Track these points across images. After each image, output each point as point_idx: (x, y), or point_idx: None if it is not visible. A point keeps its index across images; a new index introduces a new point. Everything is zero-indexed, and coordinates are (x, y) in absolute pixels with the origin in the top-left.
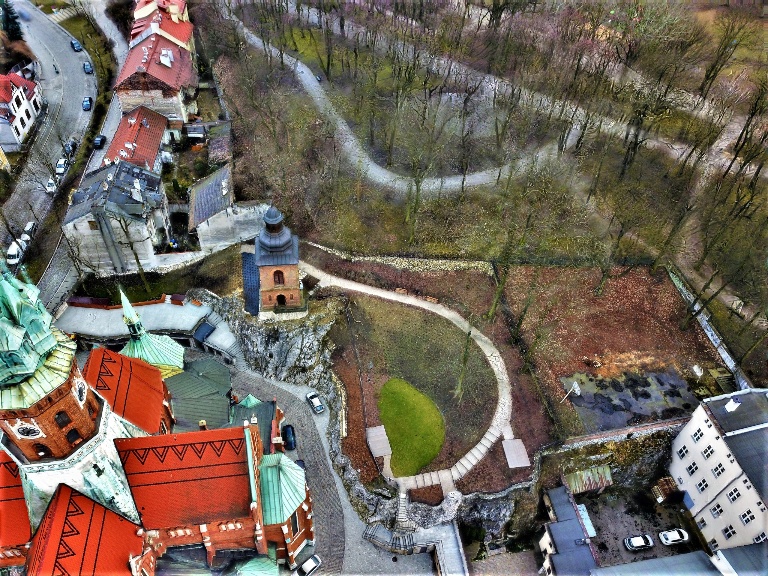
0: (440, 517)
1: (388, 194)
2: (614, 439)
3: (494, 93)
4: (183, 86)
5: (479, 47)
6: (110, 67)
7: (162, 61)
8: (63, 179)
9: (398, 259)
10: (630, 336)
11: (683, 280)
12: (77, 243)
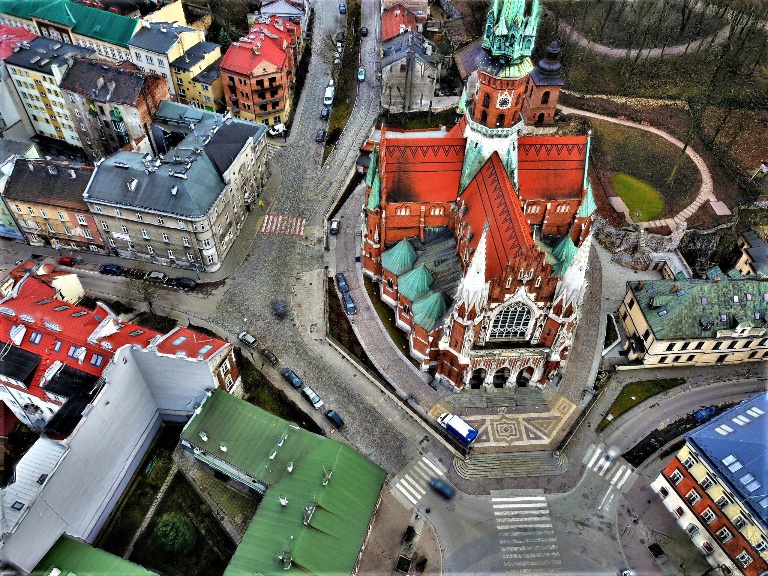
0: (669, 245)
1: (605, 57)
2: None
3: None
4: None
5: None
6: None
7: None
8: (342, 56)
9: (619, 97)
10: None
11: None
12: (387, 83)
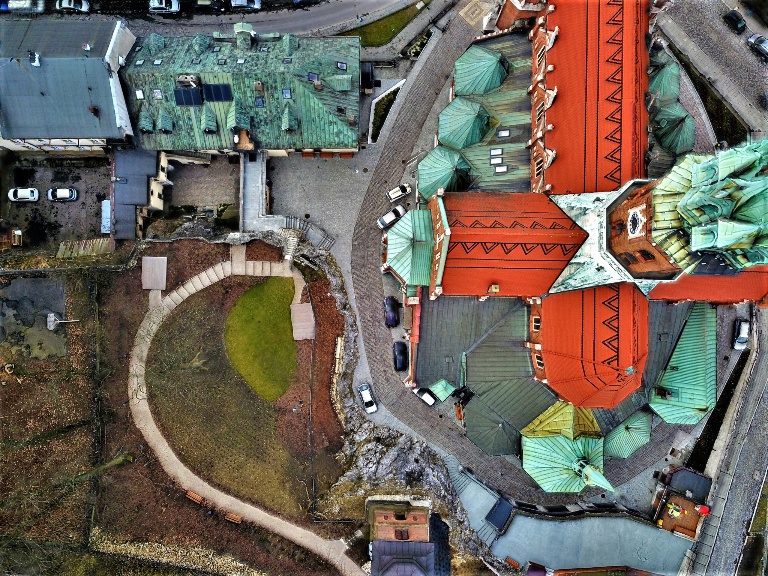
0: None
1: None
2: None
3: None
4: None
5: None
6: None
7: None
8: None
9: (226, 571)
10: None
11: None
12: None
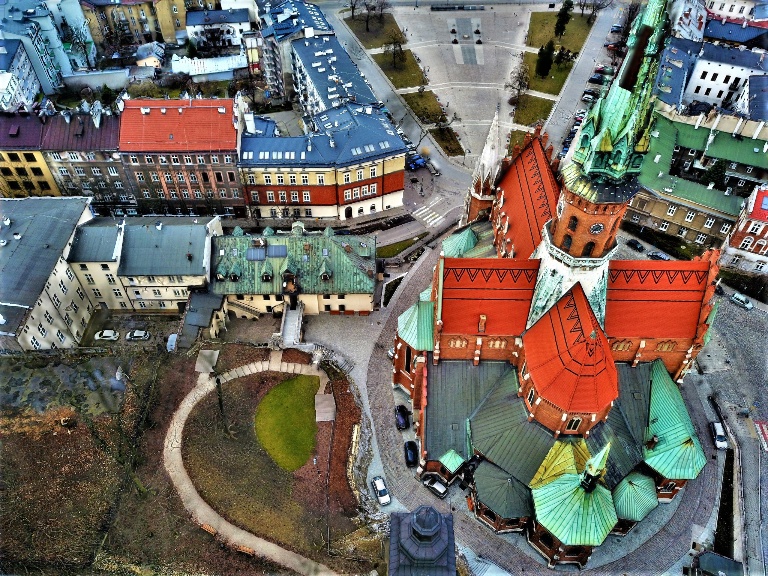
0: None
1: None
2: None
3: None
4: None
5: None
6: None
7: None
8: None
9: None
10: None
11: None
12: None
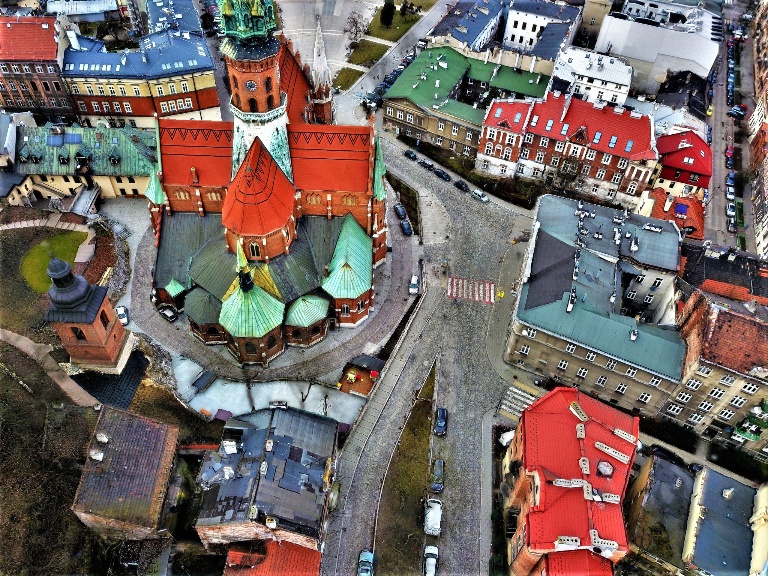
0: None
1: None
2: None
3: None
4: None
5: None
6: None
7: None
8: None
9: None
10: None
11: None
12: None
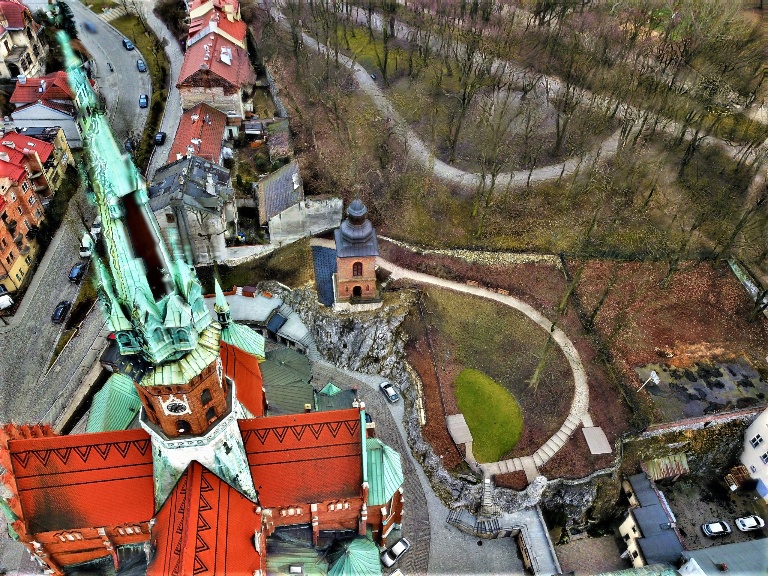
0: (524, 502)
1: (454, 189)
2: (692, 427)
3: (547, 91)
4: (243, 83)
5: (528, 46)
6: (164, 65)
7: (222, 59)
8: None
9: (468, 252)
10: (698, 328)
11: (747, 274)
12: None
